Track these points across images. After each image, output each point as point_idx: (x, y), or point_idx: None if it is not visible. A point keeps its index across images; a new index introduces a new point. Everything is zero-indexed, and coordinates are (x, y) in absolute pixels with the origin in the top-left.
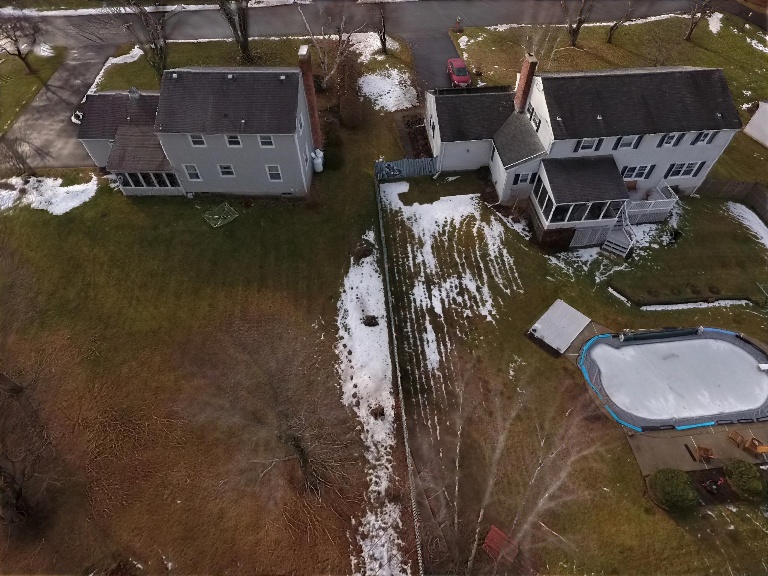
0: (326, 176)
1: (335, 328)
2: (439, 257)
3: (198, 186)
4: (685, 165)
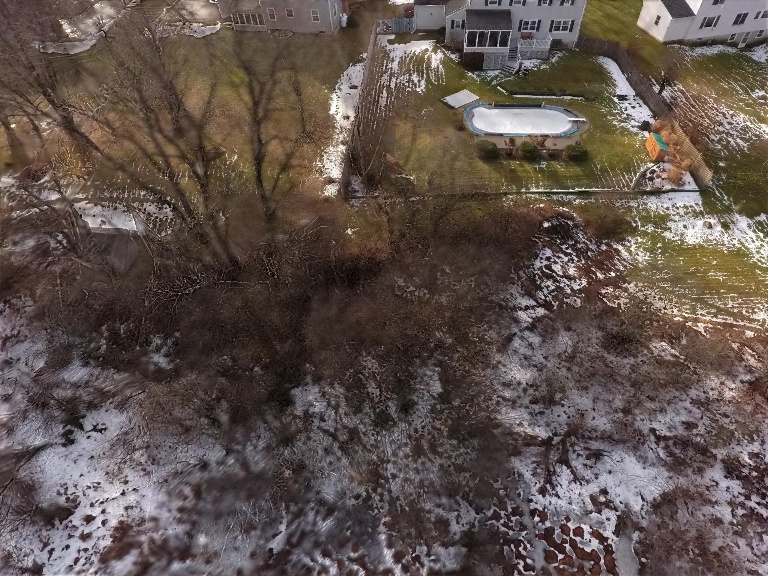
0: (347, 29)
1: (334, 89)
2: (401, 66)
3: (274, 25)
4: (562, 22)
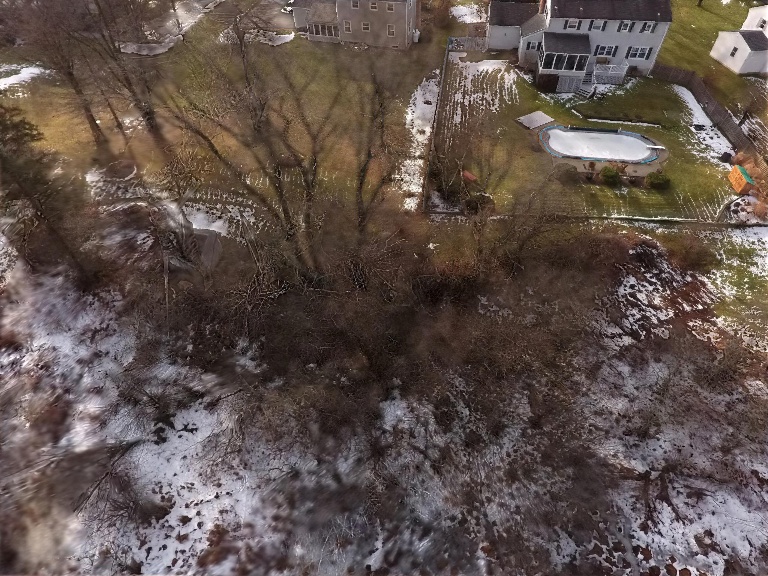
0: (419, 45)
1: (408, 103)
2: (474, 84)
3: (348, 37)
4: (639, 49)
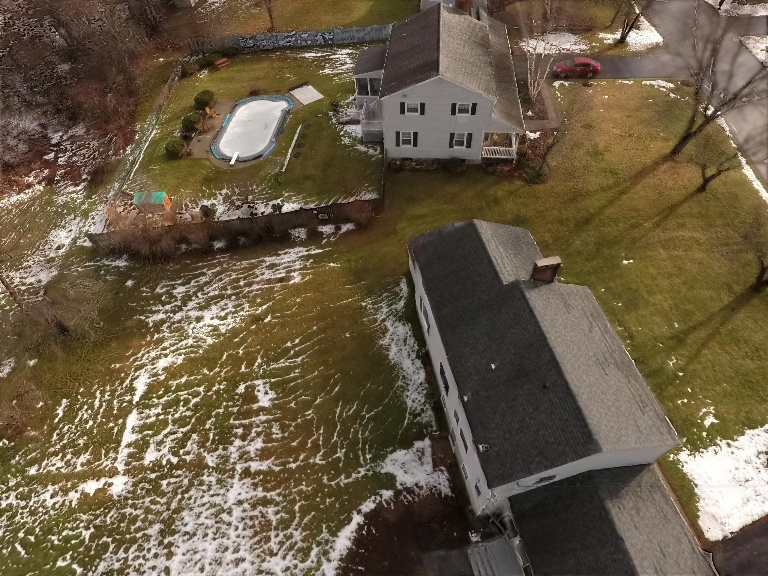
0: None
1: None
2: None
3: None
4: None
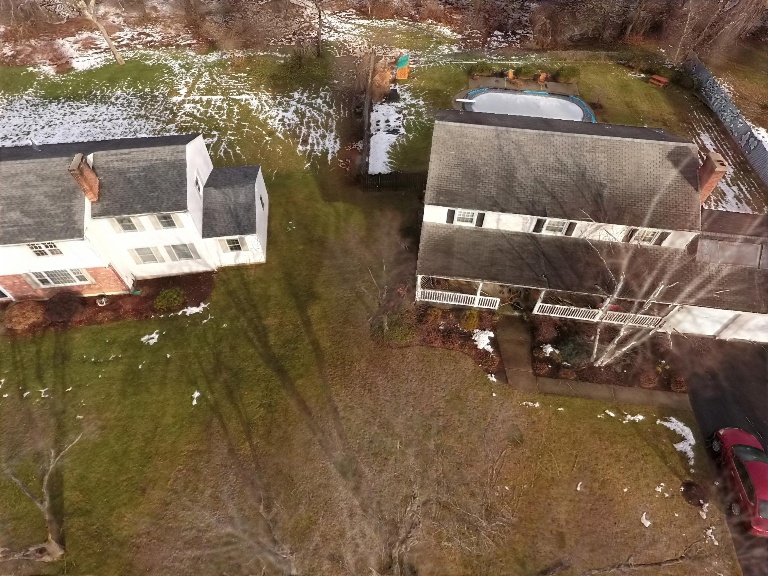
0: None
1: None
2: None
3: None
4: None
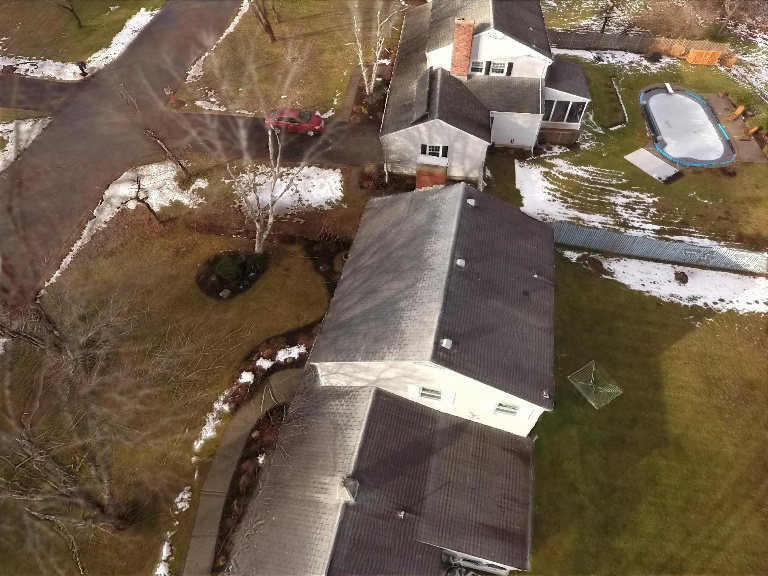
0: None
1: (696, 308)
2: (594, 211)
3: None
4: None
